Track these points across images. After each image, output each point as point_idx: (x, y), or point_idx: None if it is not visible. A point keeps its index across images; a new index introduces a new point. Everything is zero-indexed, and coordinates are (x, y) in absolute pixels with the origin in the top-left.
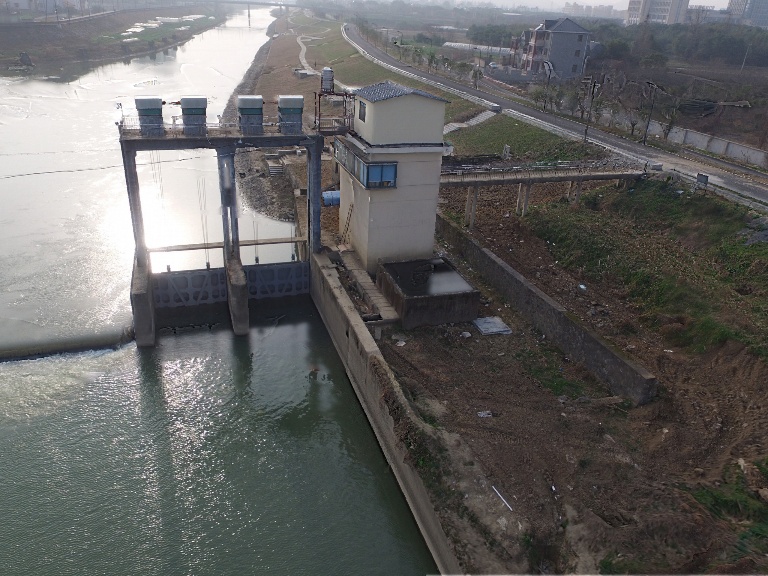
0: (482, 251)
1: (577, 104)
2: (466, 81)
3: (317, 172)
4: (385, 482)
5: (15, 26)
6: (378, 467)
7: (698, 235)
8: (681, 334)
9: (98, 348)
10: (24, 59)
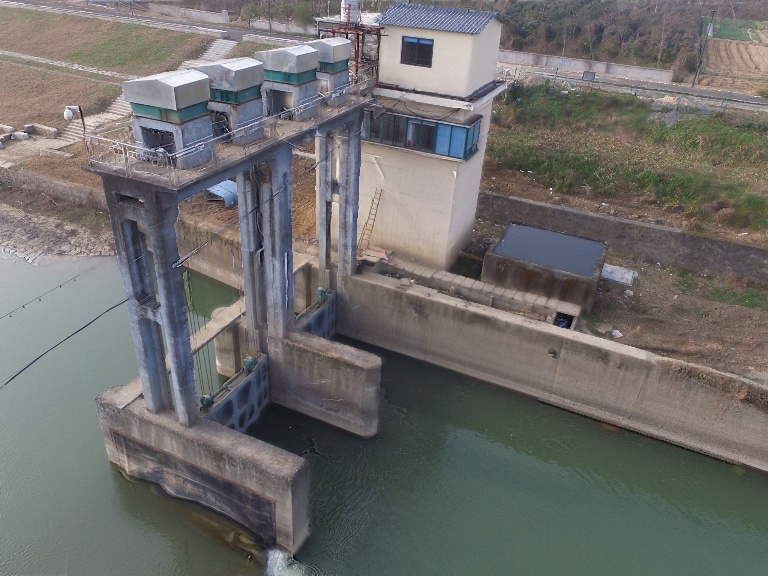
0: (514, 200)
1: (312, 20)
2: (92, 6)
3: (358, 157)
4: (753, 484)
5: None
6: (726, 475)
7: (624, 128)
8: (738, 216)
9: None
10: None
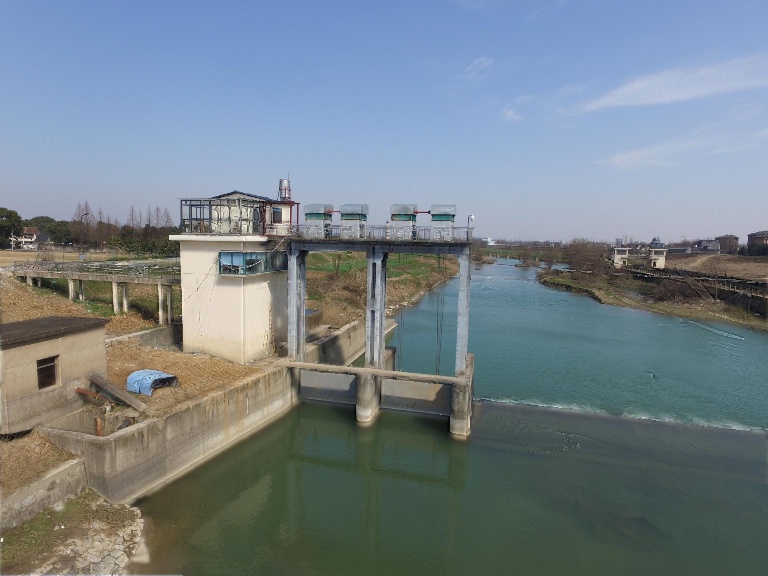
0: None
1: None
2: None
3: None
4: None
5: None
6: None
7: None
8: None
9: None
10: None
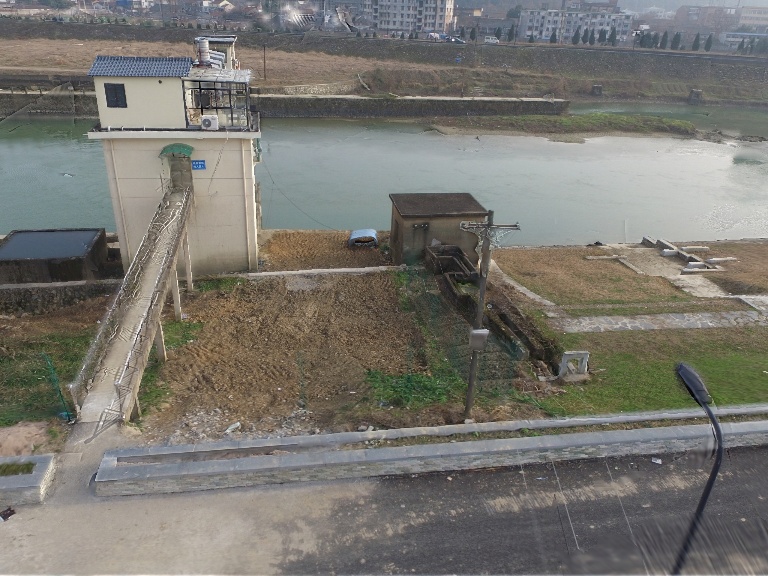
0: None
1: None
2: None
3: None
4: None
5: None
6: None
7: None
8: None
9: None
10: None
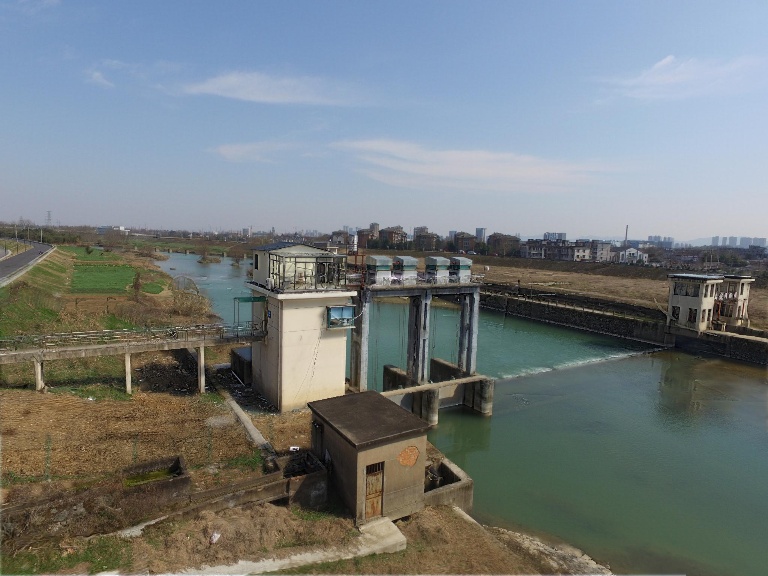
0: None
1: None
2: None
3: None
4: None
5: None
6: None
7: None
8: None
9: None
10: None
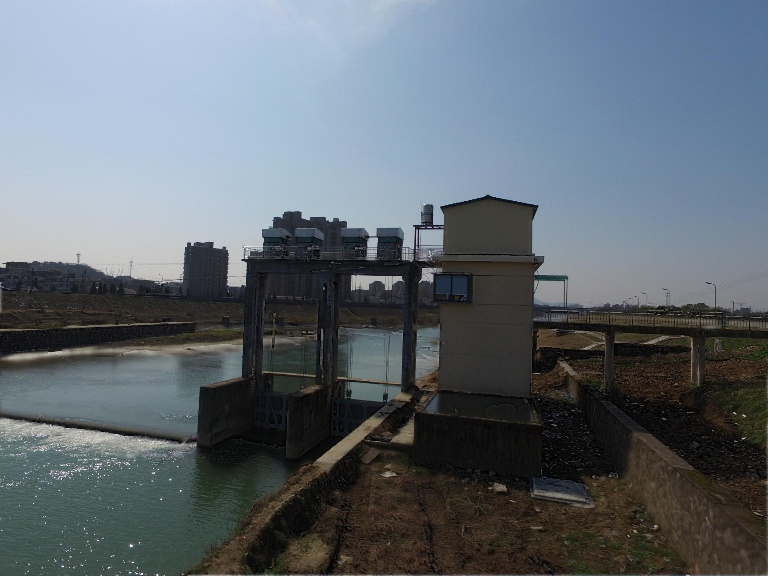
0: (598, 402)
1: None
2: None
3: (409, 301)
4: None
5: (376, 305)
6: None
7: None
8: None
9: (170, 438)
10: (373, 322)
